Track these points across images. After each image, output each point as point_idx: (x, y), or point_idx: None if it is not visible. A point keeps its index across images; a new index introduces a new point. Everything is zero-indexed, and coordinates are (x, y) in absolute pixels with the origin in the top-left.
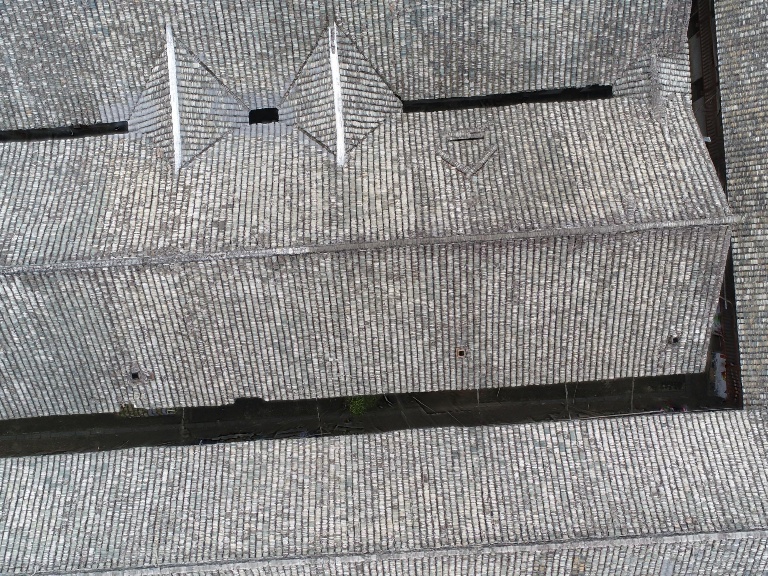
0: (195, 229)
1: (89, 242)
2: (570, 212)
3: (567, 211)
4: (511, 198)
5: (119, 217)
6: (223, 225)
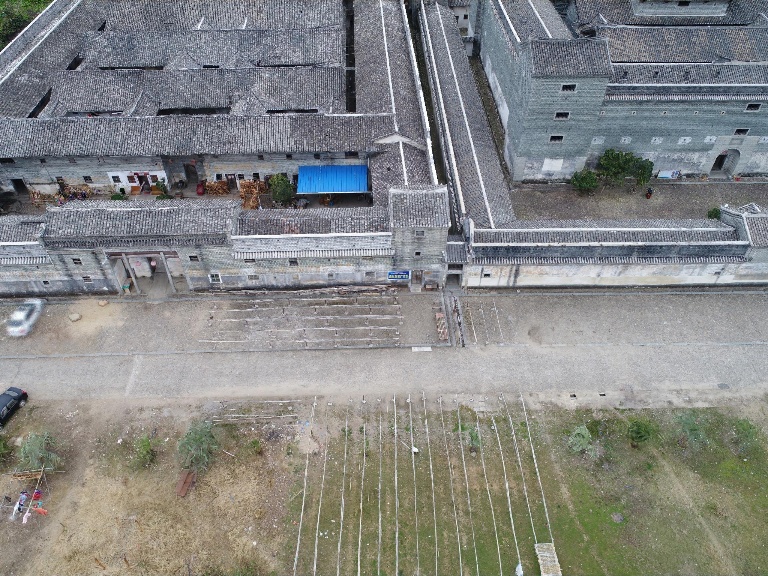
0: (242, 4)
1: (269, 3)
2: (148, 3)
3: (149, 3)
4: (161, 8)
5: (262, 8)
6: (235, 5)
